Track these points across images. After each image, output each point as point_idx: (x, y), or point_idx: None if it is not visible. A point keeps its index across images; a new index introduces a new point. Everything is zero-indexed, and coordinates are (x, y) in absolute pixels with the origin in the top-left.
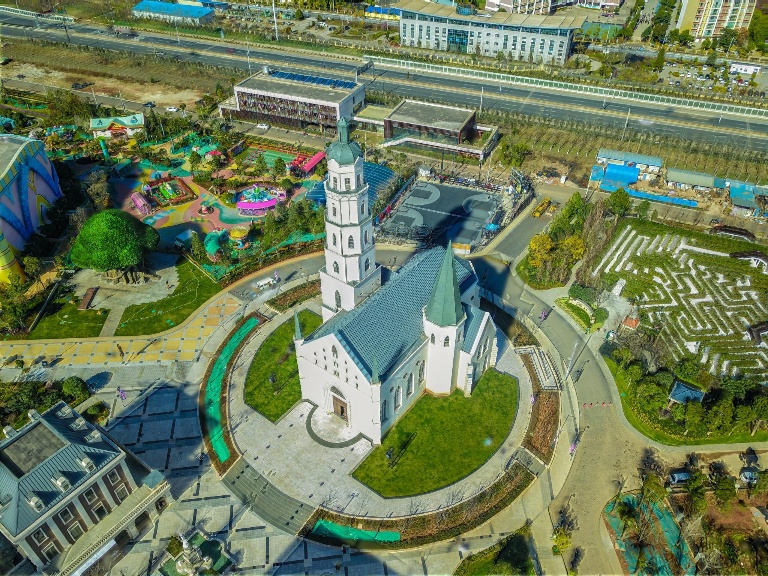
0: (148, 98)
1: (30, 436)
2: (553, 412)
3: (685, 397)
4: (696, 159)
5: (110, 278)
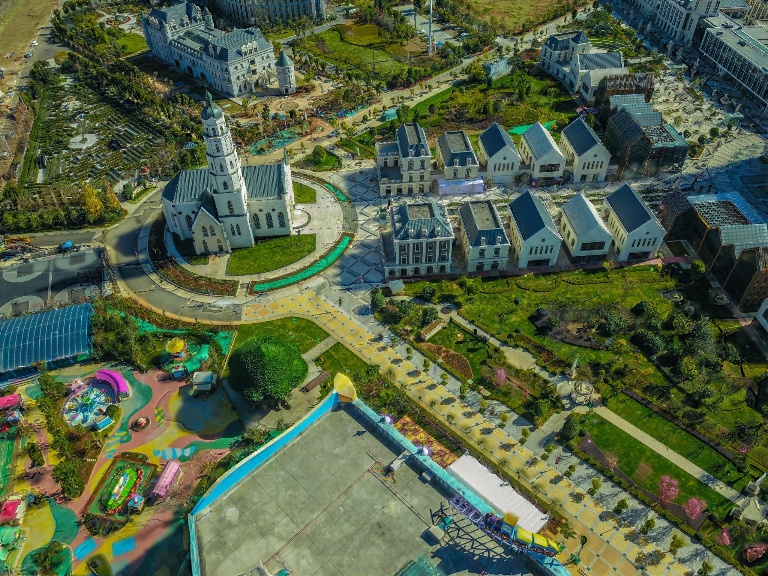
0: None
1: None
2: None
3: None
4: None
5: None
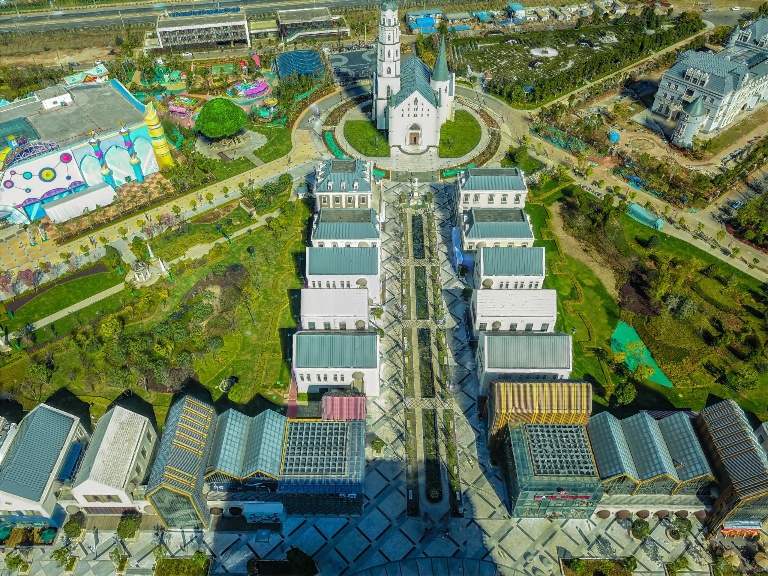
0: (62, 61)
1: (335, 166)
2: (487, 115)
3: (530, 89)
4: (449, 8)
5: (225, 144)
